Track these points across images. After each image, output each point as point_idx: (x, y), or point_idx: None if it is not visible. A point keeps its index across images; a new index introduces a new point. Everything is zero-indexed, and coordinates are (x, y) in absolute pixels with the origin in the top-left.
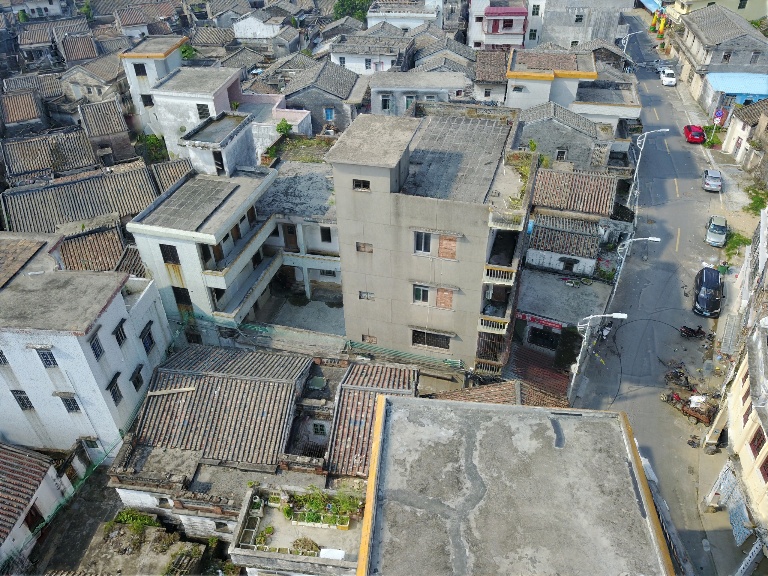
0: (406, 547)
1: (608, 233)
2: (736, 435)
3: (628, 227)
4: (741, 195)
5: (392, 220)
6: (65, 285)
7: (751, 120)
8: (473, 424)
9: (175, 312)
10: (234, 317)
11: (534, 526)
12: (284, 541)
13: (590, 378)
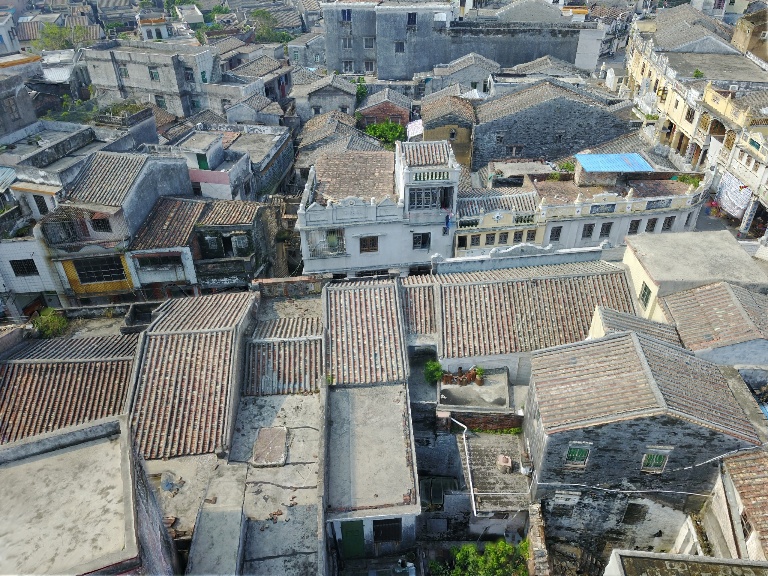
0: None
1: (621, 25)
2: None
3: (629, 23)
4: None
5: None
6: None
7: None
8: None
9: None
10: None
11: None
12: None
13: (600, 61)
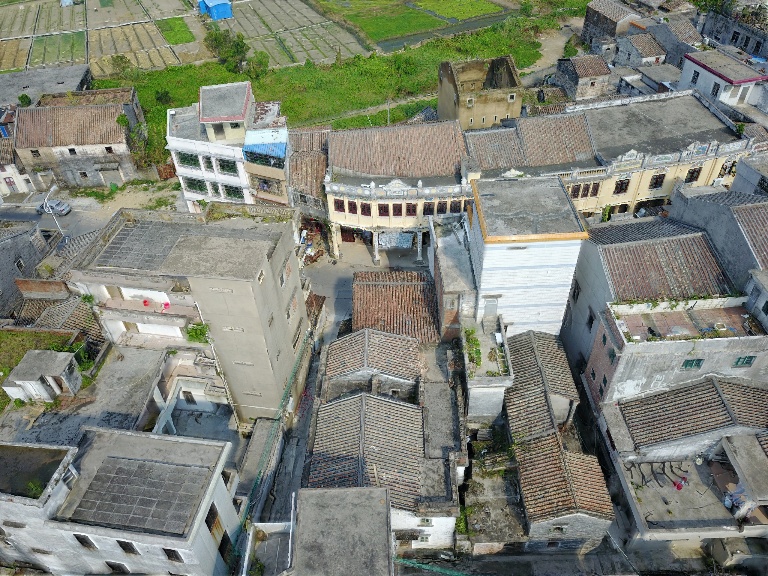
0: (554, 228)
1: None
2: (367, 223)
3: None
4: (81, 200)
5: (273, 282)
6: (317, 547)
7: (7, 160)
8: (491, 215)
9: (227, 570)
10: (246, 498)
11: (532, 201)
12: (493, 366)
13: None
